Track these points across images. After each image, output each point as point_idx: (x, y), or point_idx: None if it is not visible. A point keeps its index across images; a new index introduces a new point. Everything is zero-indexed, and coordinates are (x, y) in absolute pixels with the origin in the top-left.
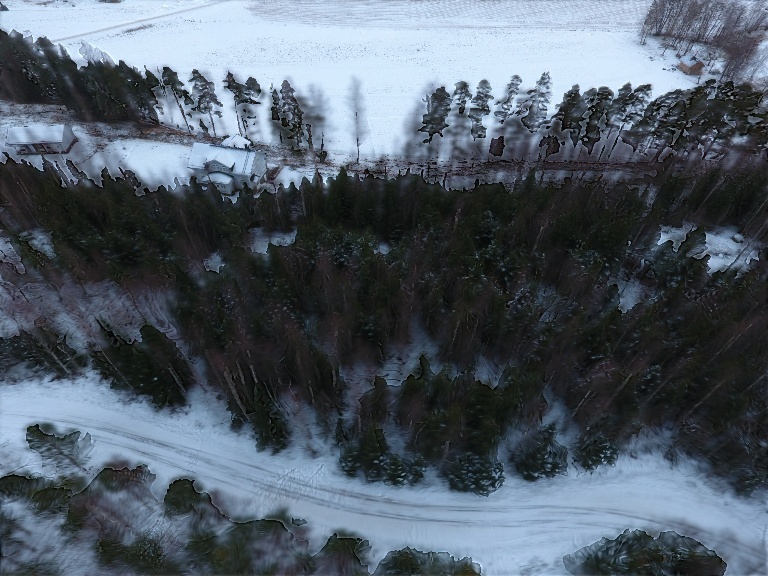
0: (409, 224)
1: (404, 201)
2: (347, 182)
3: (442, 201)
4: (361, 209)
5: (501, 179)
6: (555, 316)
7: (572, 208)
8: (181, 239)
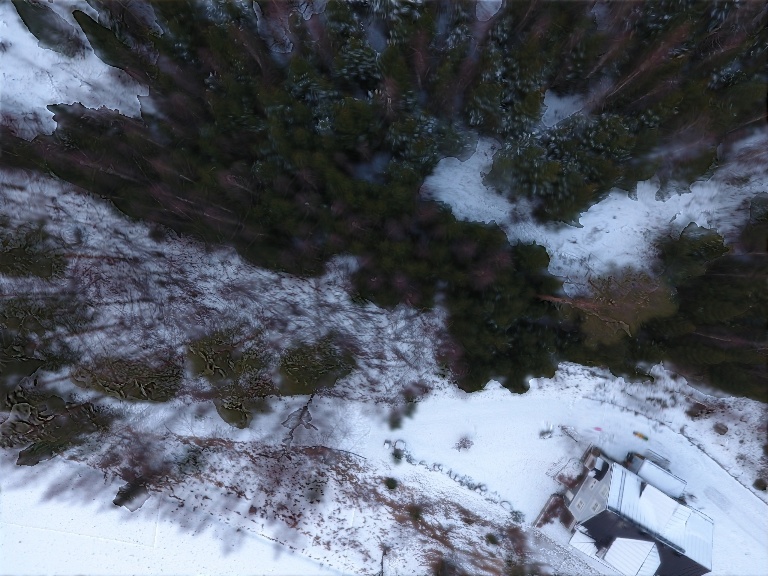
0: (422, 209)
1: (431, 215)
2: (489, 330)
3: (376, 187)
4: (498, 229)
5: (170, 413)
6: (297, 8)
7: (183, 107)
8: (767, 240)
